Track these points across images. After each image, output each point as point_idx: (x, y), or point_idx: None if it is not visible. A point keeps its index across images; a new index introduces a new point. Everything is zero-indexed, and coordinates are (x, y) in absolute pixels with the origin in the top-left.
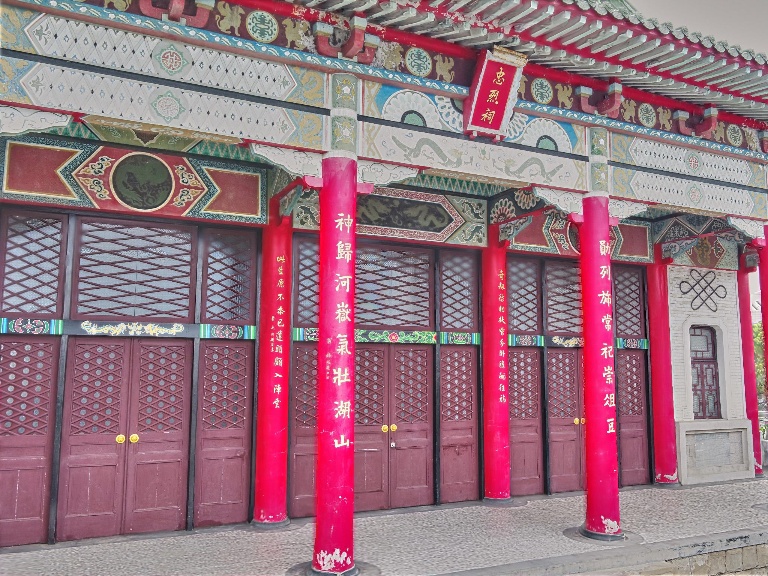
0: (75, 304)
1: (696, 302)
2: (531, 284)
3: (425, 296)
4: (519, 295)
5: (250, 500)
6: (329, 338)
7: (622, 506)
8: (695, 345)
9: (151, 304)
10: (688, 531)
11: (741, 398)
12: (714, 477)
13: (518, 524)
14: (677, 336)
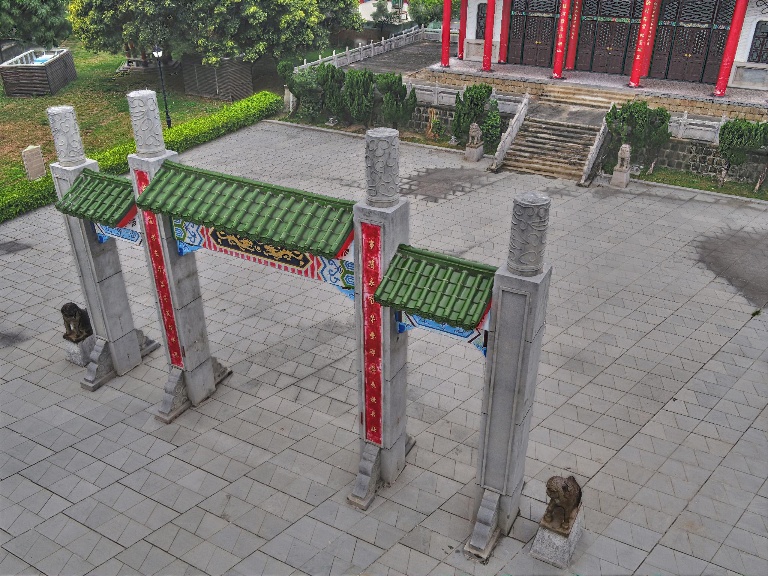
0: (528, 8)
1: (766, 10)
2: (676, 1)
3: (629, 6)
4: (669, 6)
5: (565, 63)
6: (559, 27)
7: None
8: (764, 30)
9: (546, 8)
10: None
11: None
12: (748, 86)
13: (624, 81)
14: (748, 25)
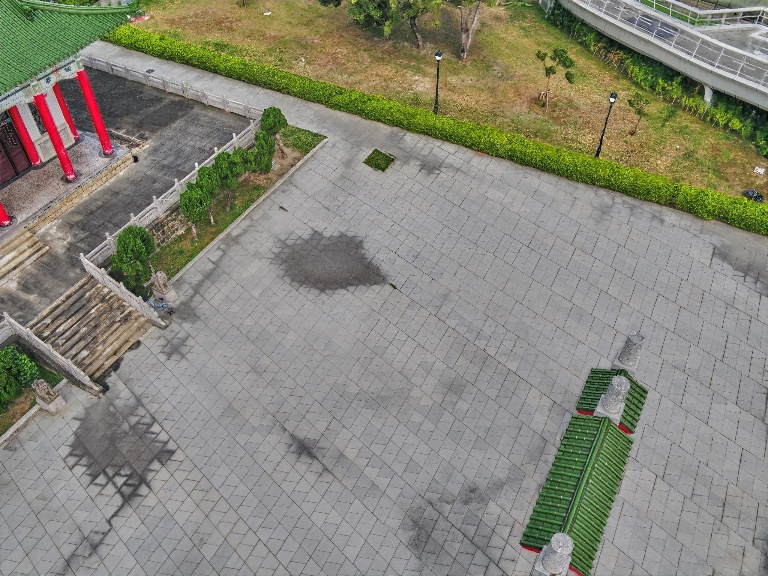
0: None
1: None
2: None
3: None
4: None
5: None
6: None
7: (16, 195)
8: (33, 105)
9: None
10: (33, 210)
11: (61, 116)
12: None
13: None
14: (23, 110)
